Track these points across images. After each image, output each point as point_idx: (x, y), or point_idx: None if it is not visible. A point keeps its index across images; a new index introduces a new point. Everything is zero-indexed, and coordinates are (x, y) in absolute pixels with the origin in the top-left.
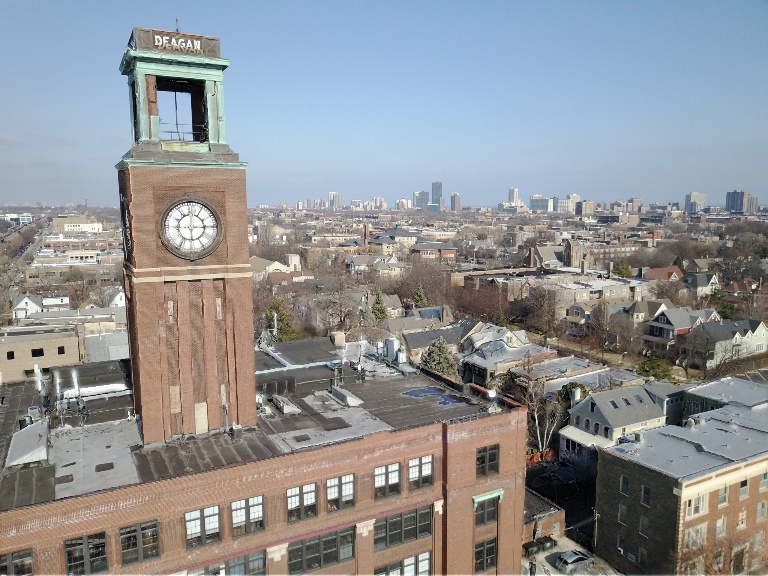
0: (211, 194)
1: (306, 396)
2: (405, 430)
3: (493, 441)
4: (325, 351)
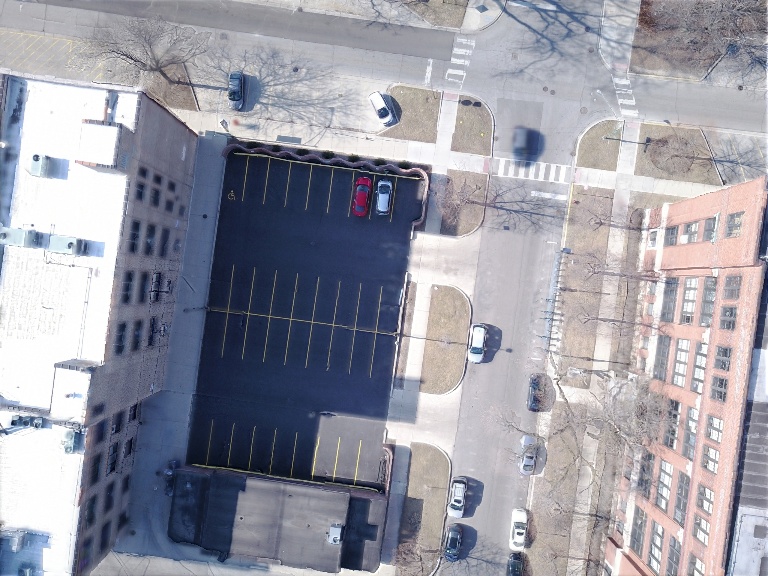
0: None
1: None
2: None
3: None
4: None
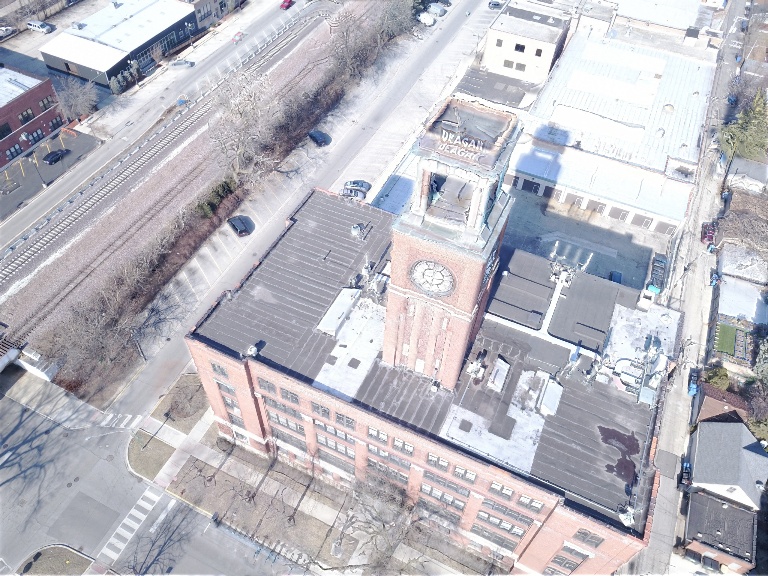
0: (455, 262)
1: (528, 370)
2: (524, 483)
3: (599, 535)
4: (607, 317)
